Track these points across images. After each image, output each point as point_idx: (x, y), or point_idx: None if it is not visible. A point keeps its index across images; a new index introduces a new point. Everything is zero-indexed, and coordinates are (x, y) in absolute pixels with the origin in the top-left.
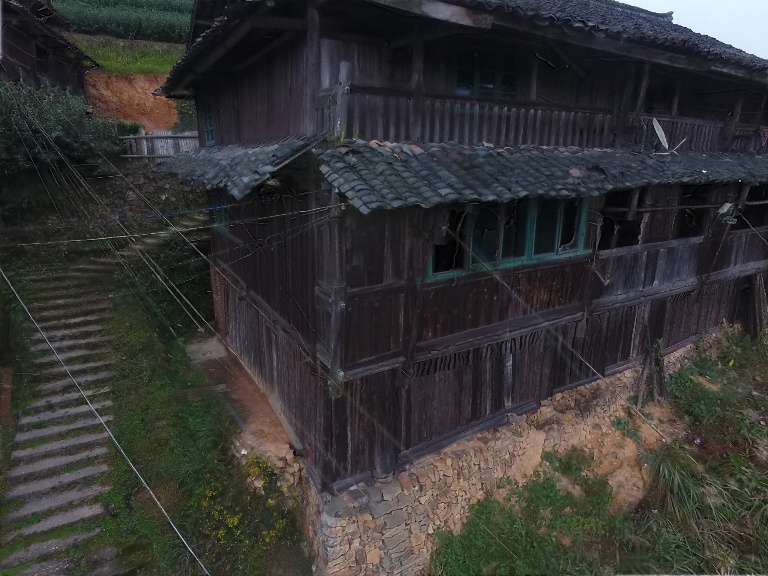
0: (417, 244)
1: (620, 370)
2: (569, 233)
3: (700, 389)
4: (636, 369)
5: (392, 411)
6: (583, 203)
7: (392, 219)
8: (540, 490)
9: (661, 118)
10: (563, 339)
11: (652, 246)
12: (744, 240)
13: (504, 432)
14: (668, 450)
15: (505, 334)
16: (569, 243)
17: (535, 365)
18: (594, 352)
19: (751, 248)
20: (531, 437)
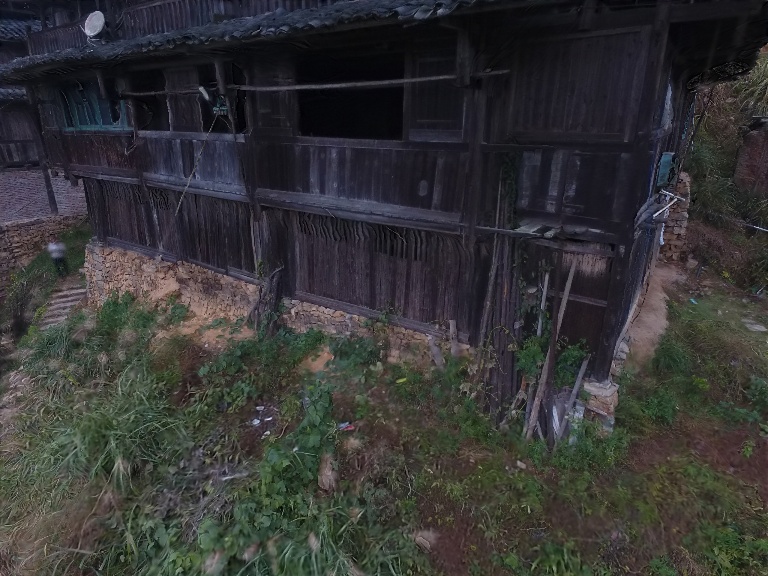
0: (58, 109)
1: (243, 278)
2: (117, 112)
3: (295, 351)
4: (264, 290)
5: (101, 209)
6: (118, 89)
7: (50, 95)
8: (145, 309)
9: (154, 4)
10: (189, 216)
11: (181, 135)
12: (335, 156)
13: (150, 262)
14: (185, 344)
15: (99, 175)
16: (119, 120)
17: (172, 227)
18: (217, 244)
19: (361, 174)
20: (169, 281)
